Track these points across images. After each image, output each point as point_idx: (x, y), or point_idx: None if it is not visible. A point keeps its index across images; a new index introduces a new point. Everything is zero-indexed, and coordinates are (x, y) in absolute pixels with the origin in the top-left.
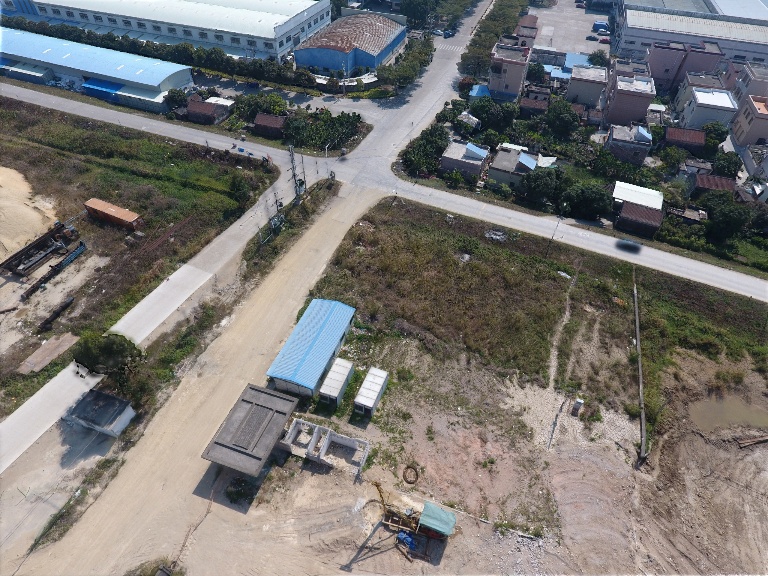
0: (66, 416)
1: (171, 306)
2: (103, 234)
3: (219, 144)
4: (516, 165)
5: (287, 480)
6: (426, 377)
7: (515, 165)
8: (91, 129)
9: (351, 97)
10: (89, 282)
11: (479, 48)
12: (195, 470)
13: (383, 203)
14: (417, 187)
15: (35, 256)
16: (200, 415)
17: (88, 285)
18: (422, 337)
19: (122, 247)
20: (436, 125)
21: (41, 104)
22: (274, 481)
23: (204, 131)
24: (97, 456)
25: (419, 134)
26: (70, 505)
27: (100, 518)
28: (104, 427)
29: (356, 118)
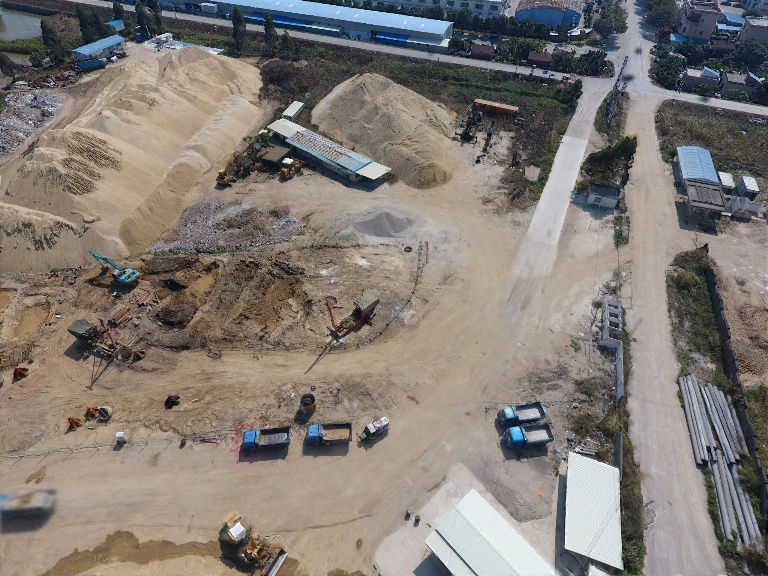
0: (573, 200)
1: (579, 155)
2: (495, 120)
3: (519, 71)
4: (744, 81)
5: (728, 224)
6: (767, 186)
7: (744, 81)
8: (415, 63)
9: (575, 44)
10: (515, 143)
11: (669, 5)
12: (672, 220)
13: (667, 103)
14: (683, 94)
15: (472, 129)
16: (651, 200)
17: (516, 144)
18: (751, 169)
19: (515, 127)
20: (674, 56)
21: (364, 48)
22: (721, 225)
23: (500, 63)
24: (610, 215)
25: (649, 66)
26: (620, 231)
27: (640, 236)
28: (617, 197)
29: (604, 54)
